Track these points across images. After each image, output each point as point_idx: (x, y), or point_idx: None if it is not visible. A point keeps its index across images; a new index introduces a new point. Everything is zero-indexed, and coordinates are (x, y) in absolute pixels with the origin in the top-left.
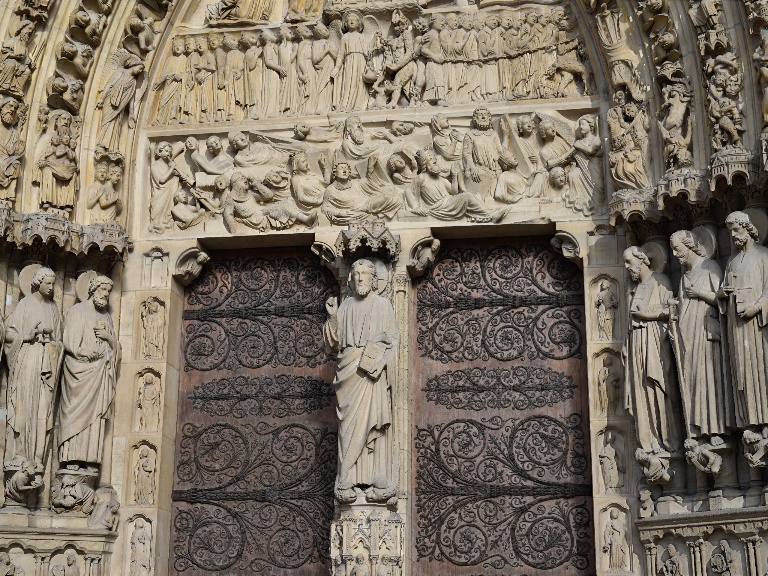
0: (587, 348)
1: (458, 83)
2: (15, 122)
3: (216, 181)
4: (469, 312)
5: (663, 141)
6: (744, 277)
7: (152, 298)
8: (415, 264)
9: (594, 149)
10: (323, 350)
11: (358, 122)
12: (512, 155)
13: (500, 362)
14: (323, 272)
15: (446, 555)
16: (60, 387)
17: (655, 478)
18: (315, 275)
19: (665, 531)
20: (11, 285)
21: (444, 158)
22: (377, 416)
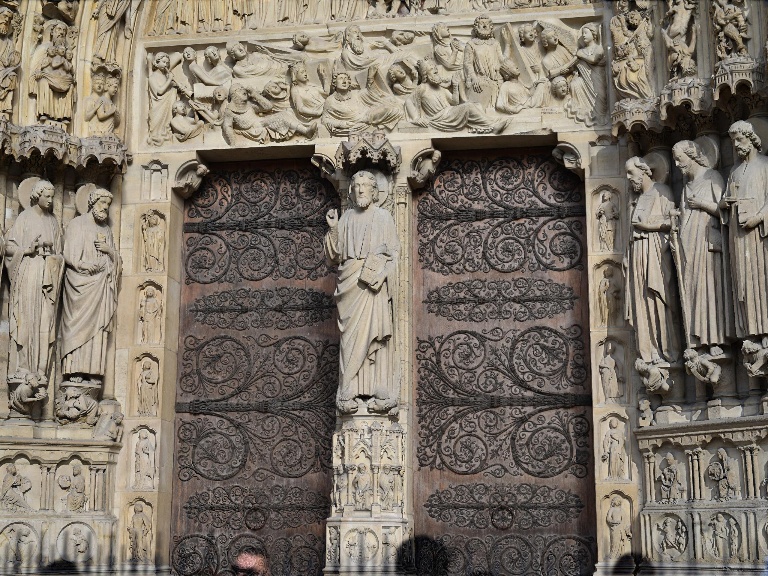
0: (588, 259)
1: None
2: (10, 33)
3: (214, 92)
4: (470, 224)
5: (667, 49)
6: (746, 187)
7: (152, 211)
8: (416, 176)
9: (597, 58)
10: (324, 262)
11: (358, 31)
12: (514, 65)
13: (501, 274)
14: (323, 184)
15: (447, 464)
16: (62, 300)
17: (654, 388)
18: (315, 187)
19: (664, 440)
20: (10, 198)
21: (445, 68)
22: (378, 328)
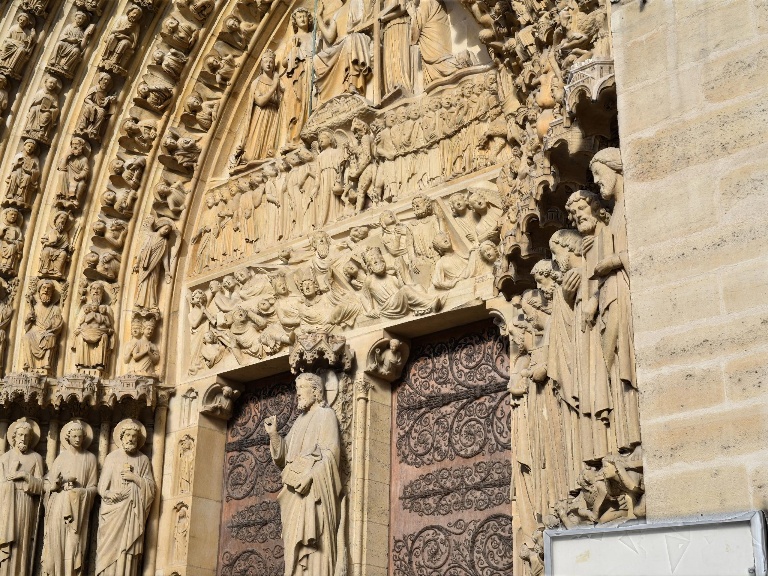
0: None
1: (407, 175)
2: (58, 300)
3: (224, 318)
4: (439, 410)
5: None
6: (545, 334)
7: (186, 436)
8: (372, 369)
9: None
10: None
11: (321, 237)
12: (442, 238)
13: (464, 460)
14: None
15: None
16: (97, 528)
17: None
18: None
19: None
20: None
21: (392, 255)
22: (305, 532)
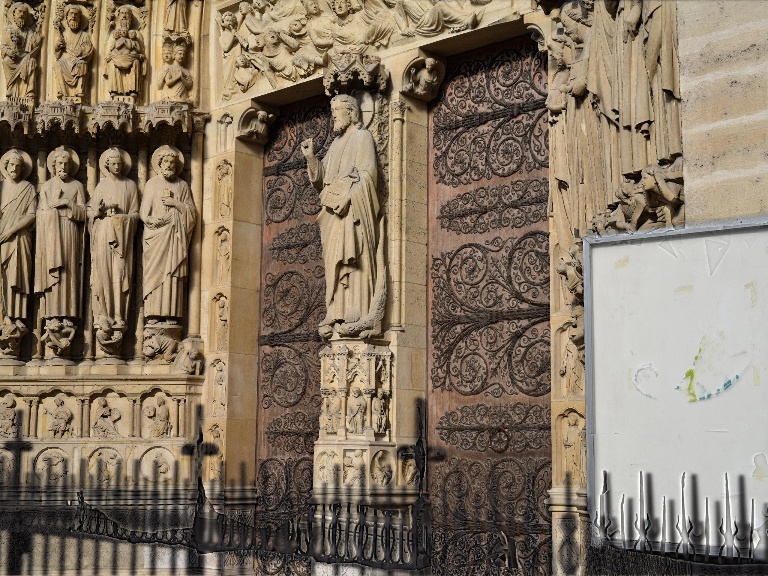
0: None
1: None
2: (86, 26)
3: (256, 41)
4: (476, 129)
5: None
6: (585, 47)
7: (224, 162)
8: (408, 89)
9: None
10: None
11: None
12: None
13: (501, 179)
14: None
15: (454, 385)
16: (142, 253)
17: (576, 291)
18: None
19: None
20: None
21: None
22: (345, 252)
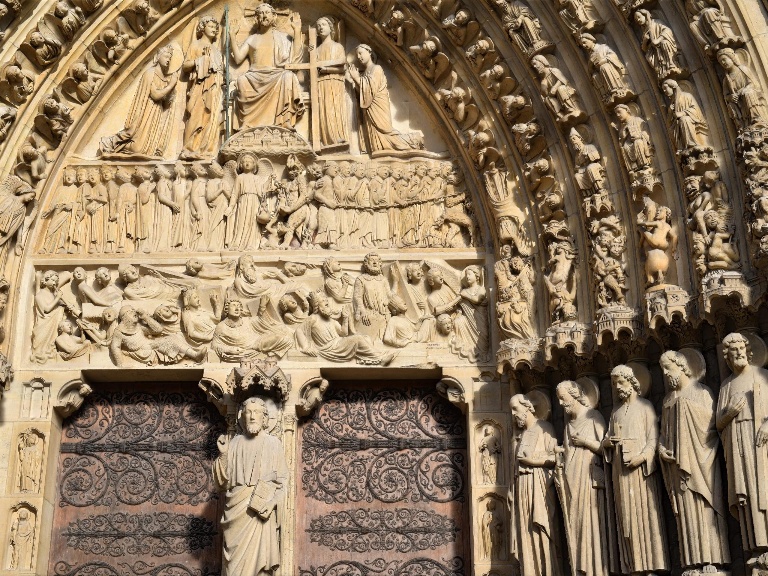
0: (472, 492)
1: (350, 228)
2: None
3: (104, 313)
4: (354, 453)
5: (549, 295)
6: (629, 428)
7: (31, 430)
8: (304, 404)
9: (480, 298)
10: (206, 488)
11: (251, 261)
12: (402, 301)
13: (384, 504)
14: (208, 408)
15: None
16: None
17: None
18: (200, 411)
19: None
20: None
21: (335, 300)
22: (266, 557)
